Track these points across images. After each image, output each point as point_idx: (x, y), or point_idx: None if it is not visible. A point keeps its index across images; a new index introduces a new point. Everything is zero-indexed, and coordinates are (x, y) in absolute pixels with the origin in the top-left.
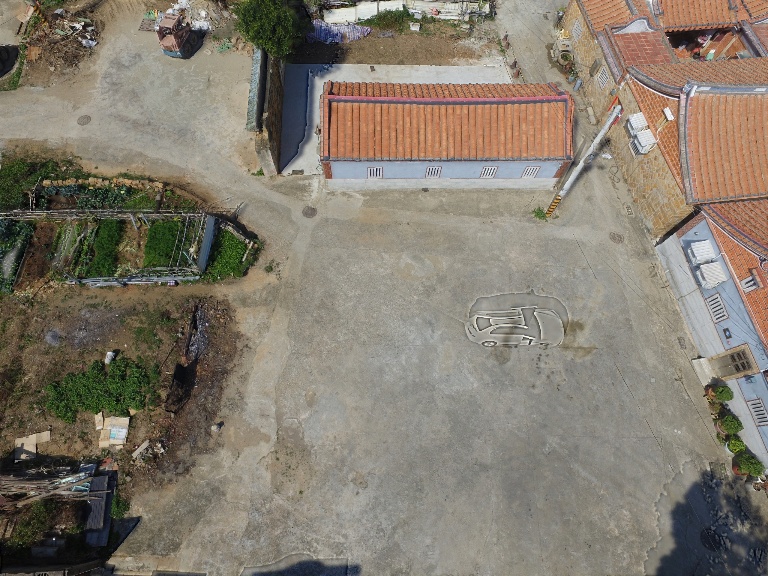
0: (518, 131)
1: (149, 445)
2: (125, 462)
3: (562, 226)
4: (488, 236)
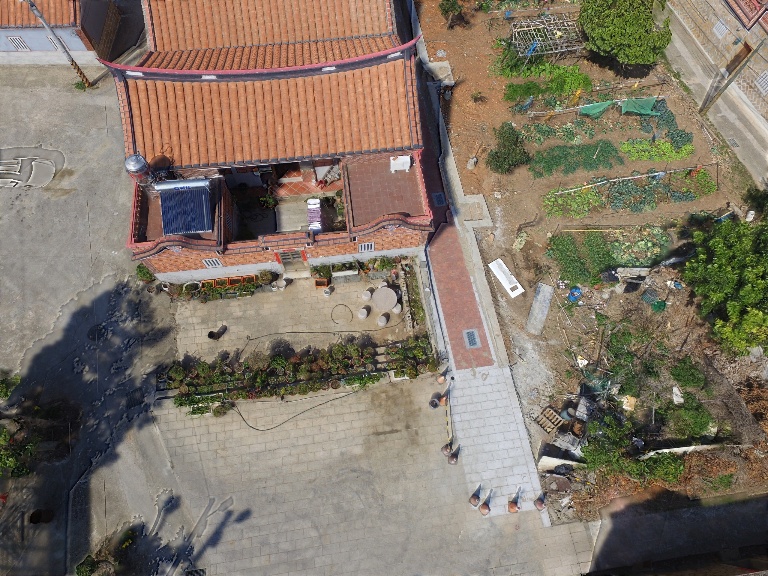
0: None
1: None
2: None
3: (97, 95)
4: (21, 102)
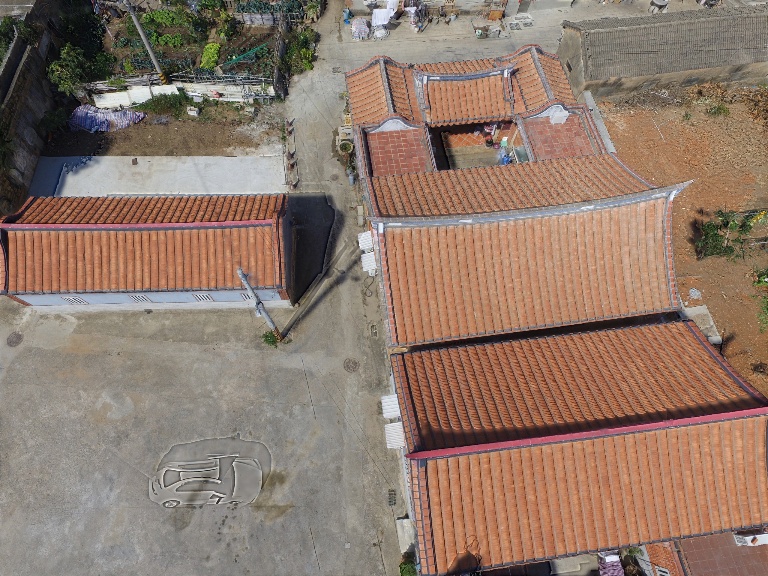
0: (222, 258)
1: None
2: None
3: (292, 353)
4: (205, 367)
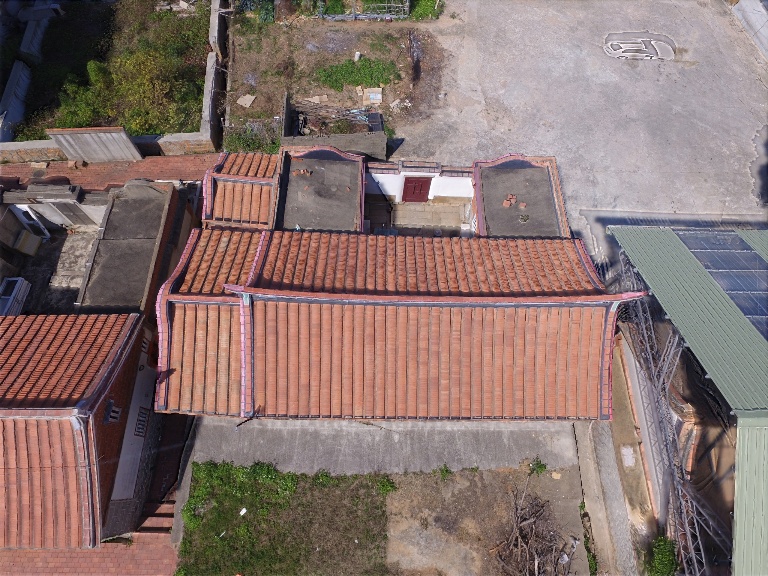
0: None
1: (400, 102)
2: (386, 110)
3: None
4: None
